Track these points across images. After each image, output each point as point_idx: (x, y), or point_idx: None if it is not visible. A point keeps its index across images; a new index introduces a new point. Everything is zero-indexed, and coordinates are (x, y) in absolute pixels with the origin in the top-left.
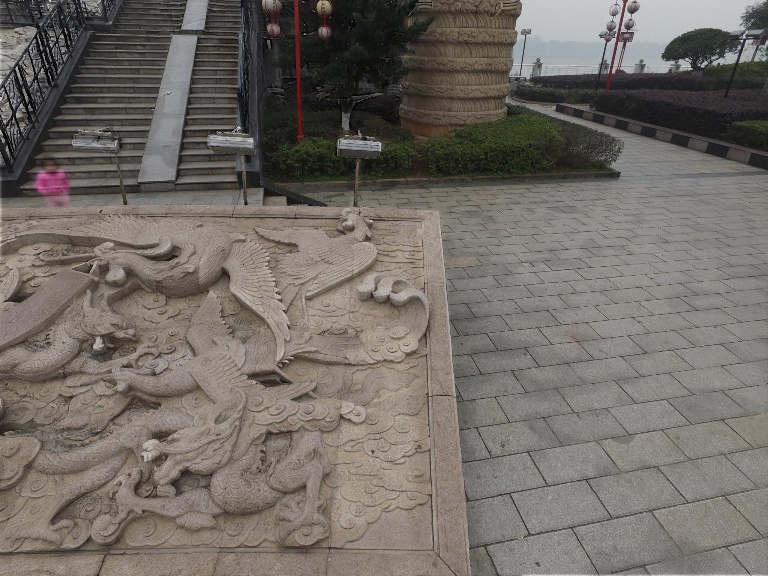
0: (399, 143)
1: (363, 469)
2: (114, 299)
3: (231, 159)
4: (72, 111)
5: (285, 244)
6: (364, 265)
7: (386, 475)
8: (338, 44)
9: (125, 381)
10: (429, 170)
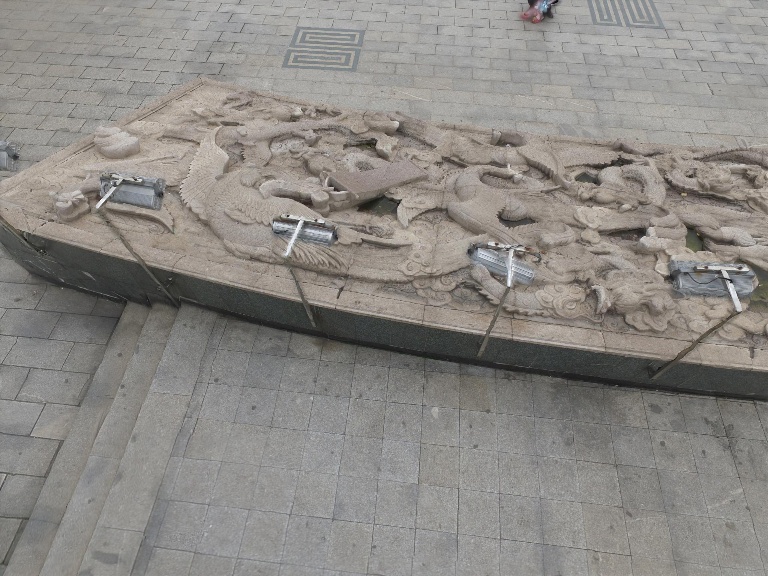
0: None
1: None
2: None
3: None
4: None
5: None
6: None
7: None
8: None
9: None
10: None
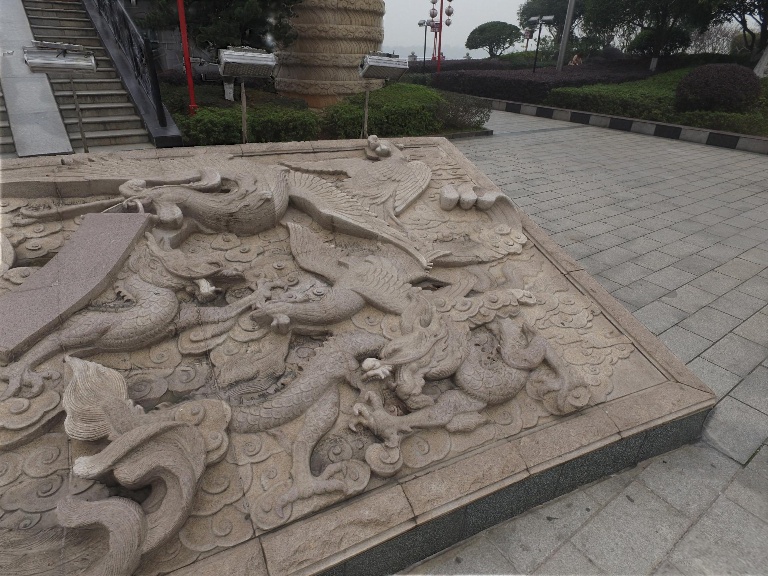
0: (301, 110)
1: (567, 339)
2: (173, 245)
3: (133, 127)
4: None
5: (329, 173)
6: (427, 181)
7: (588, 338)
8: (218, 3)
9: (284, 312)
10: (337, 136)
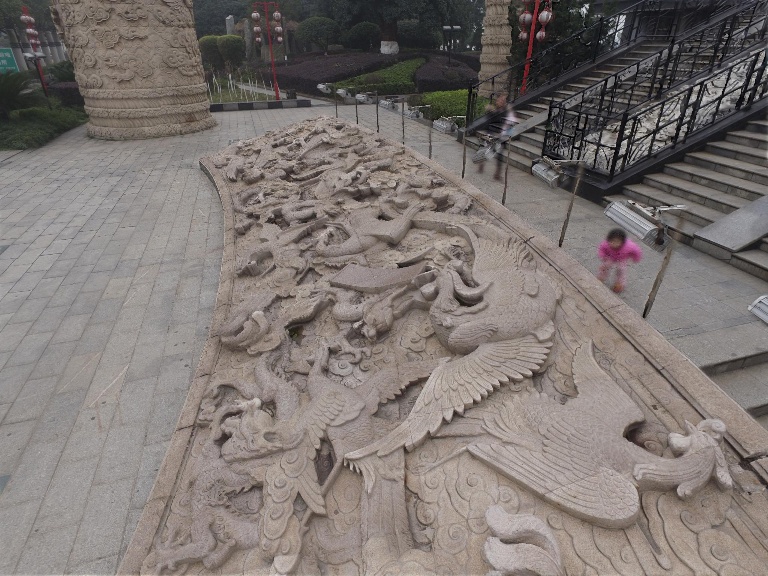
0: None
1: None
2: (419, 306)
3: None
4: (737, 139)
5: None
6: (576, 506)
7: None
8: None
9: None
10: None
